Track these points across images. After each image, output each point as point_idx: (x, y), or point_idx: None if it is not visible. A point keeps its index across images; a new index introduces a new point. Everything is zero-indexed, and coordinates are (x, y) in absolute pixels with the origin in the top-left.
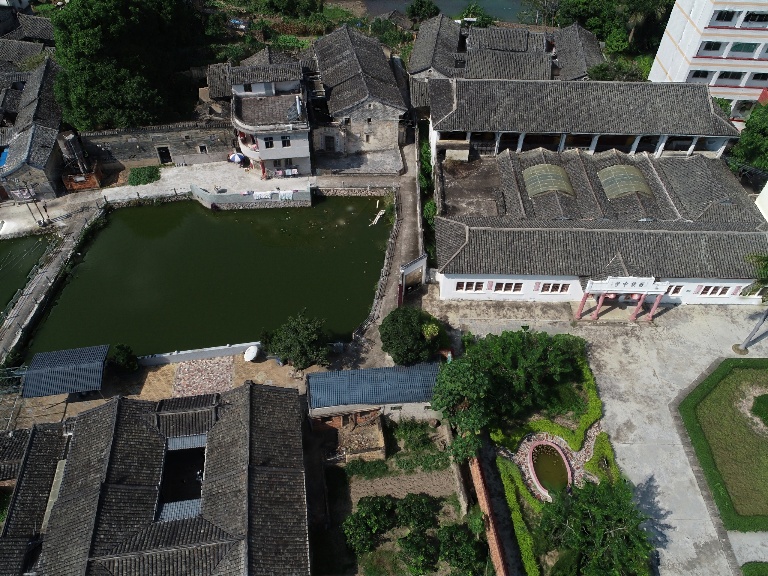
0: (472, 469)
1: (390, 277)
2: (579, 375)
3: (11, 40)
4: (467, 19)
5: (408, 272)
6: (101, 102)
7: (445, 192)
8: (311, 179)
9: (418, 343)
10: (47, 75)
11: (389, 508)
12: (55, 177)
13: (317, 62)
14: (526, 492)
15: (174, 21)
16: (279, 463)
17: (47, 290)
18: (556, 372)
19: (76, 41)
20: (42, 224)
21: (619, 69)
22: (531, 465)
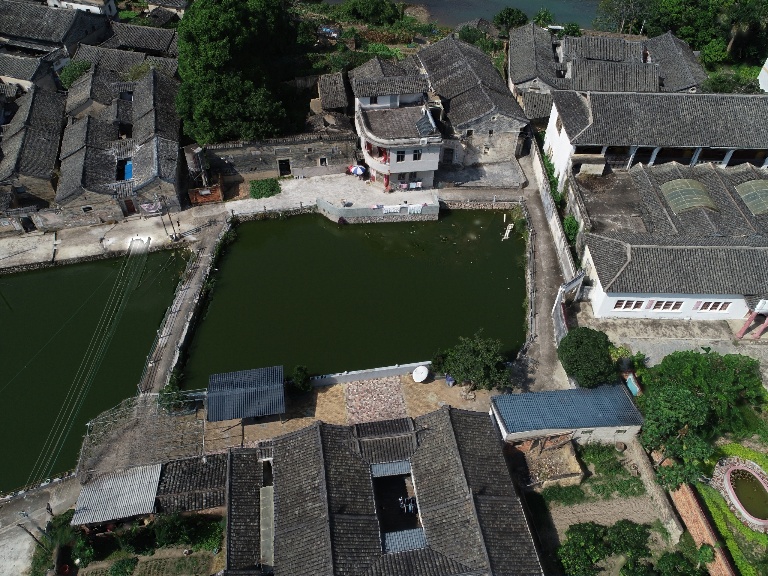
0: (675, 495)
1: (538, 294)
2: (757, 397)
3: (112, 49)
4: (552, 27)
5: (567, 290)
6: (227, 114)
7: (587, 207)
8: (434, 192)
9: (609, 366)
10: (156, 85)
11: (600, 536)
12: (179, 190)
13: (426, 72)
14: (735, 519)
15: (276, 30)
16: (494, 491)
17: (194, 307)
18: (752, 396)
19: (205, 53)
20: (174, 239)
21: (737, 81)
22: (732, 491)
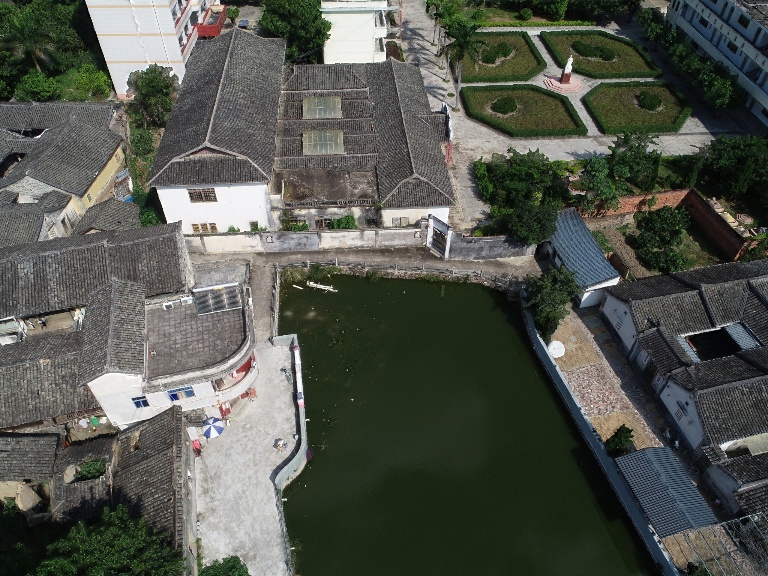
0: None
1: None
2: None
3: None
4: None
5: None
6: None
7: None
8: None
9: None
10: None
11: None
12: None
13: (3, 320)
14: None
15: None
16: None
17: None
18: None
19: None
20: None
21: (155, 73)
22: None
